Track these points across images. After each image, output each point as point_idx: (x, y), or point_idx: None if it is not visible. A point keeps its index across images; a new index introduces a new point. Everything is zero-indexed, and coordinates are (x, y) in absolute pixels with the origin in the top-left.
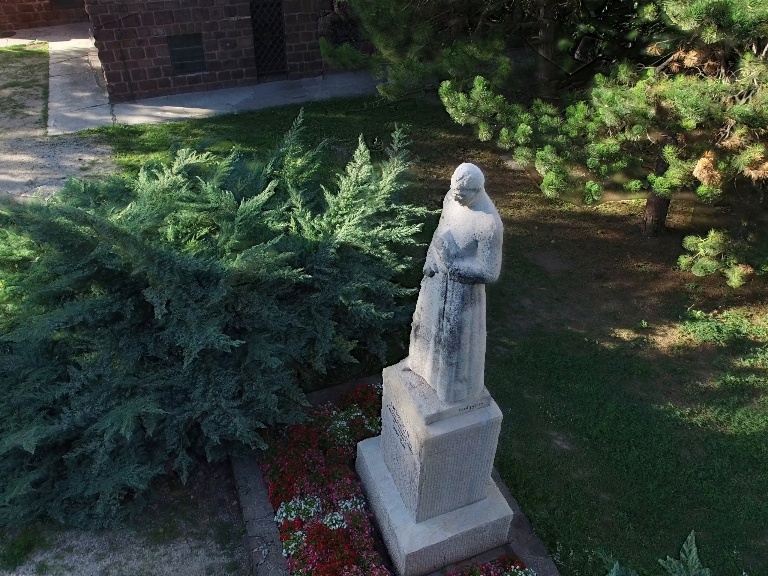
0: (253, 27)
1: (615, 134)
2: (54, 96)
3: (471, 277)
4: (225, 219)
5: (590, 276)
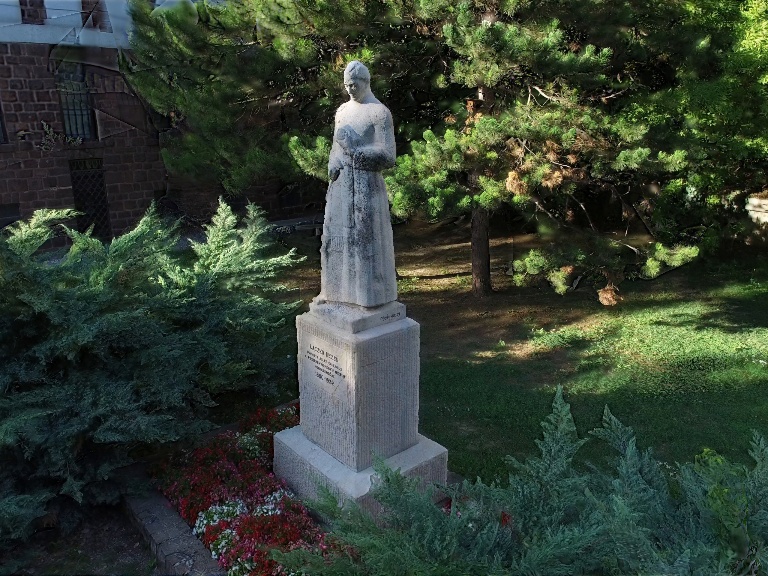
0: (74, 196)
1: None
2: None
3: (374, 158)
4: (94, 260)
5: (444, 326)
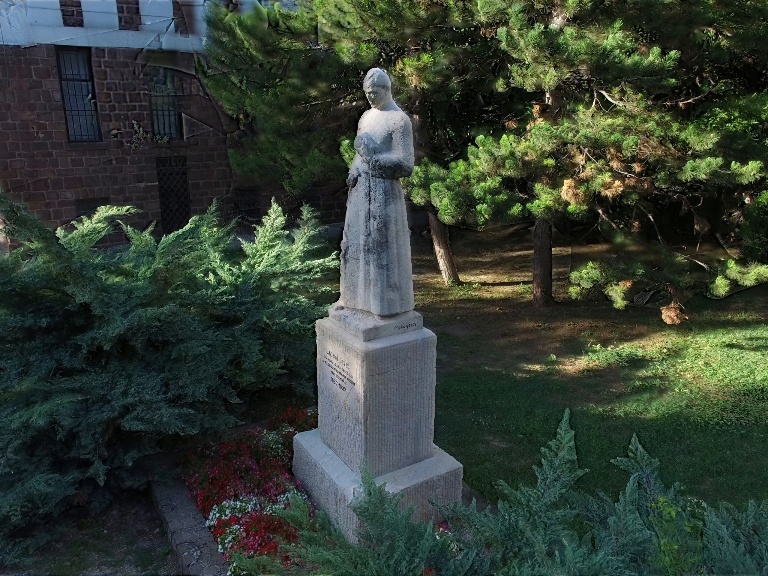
0: (160, 192)
1: (493, 178)
2: None
3: (390, 166)
4: (146, 256)
5: (497, 336)
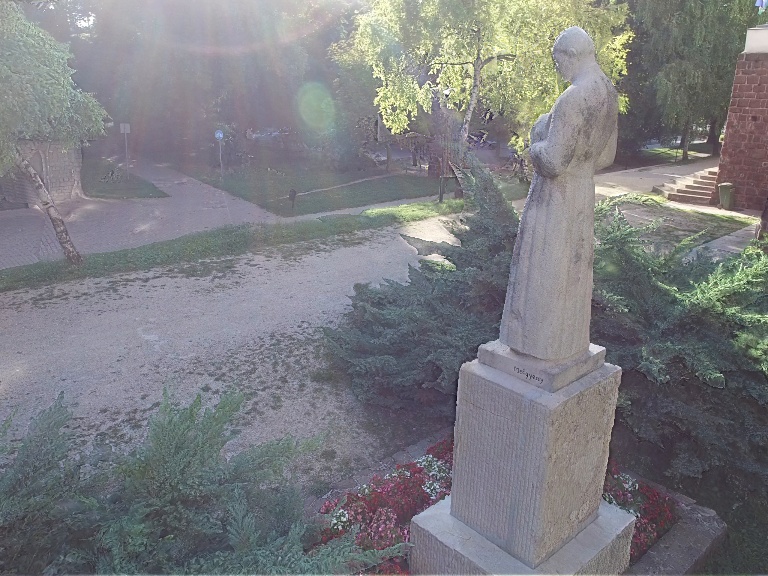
0: None
1: None
2: (711, 243)
3: None
4: None
5: None
